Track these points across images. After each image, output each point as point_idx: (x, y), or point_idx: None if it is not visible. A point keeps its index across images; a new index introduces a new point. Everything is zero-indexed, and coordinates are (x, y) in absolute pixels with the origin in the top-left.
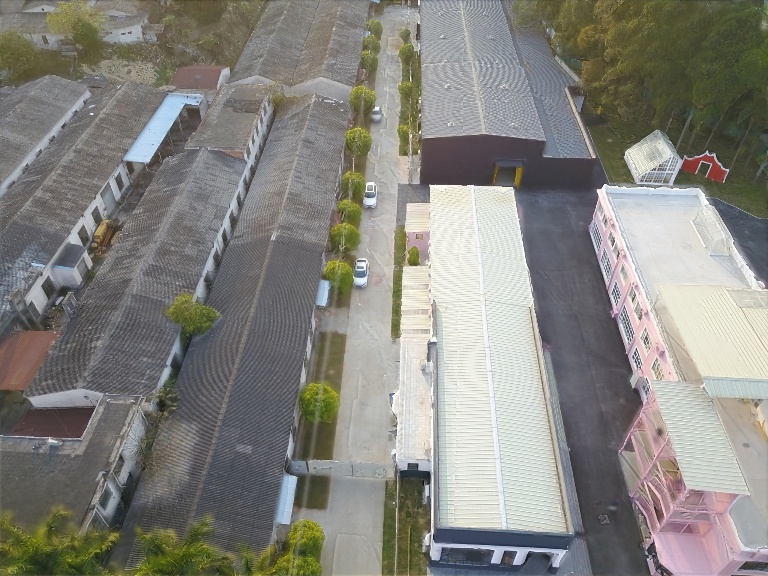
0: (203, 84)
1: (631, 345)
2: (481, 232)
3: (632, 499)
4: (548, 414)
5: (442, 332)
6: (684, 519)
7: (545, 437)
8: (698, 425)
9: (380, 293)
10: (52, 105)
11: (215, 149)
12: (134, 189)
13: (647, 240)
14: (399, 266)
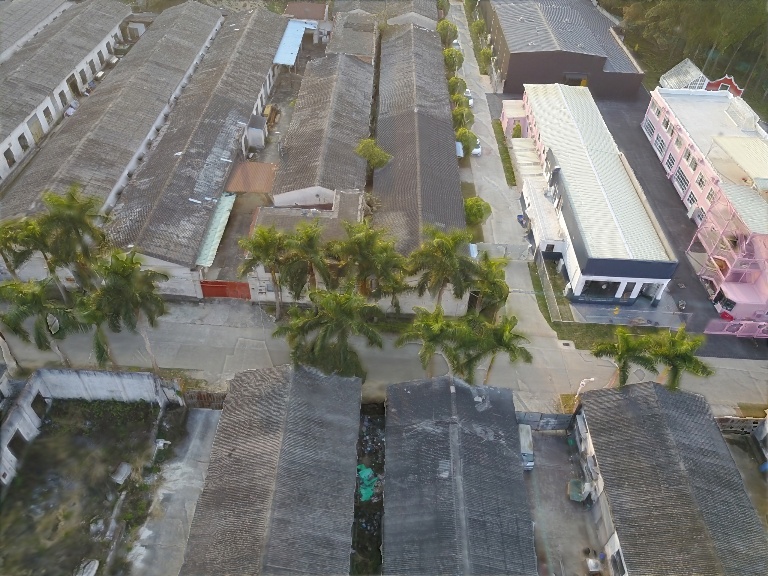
0: (313, 15)
1: (686, 191)
2: (573, 111)
3: (699, 276)
4: (646, 209)
5: (560, 166)
6: (743, 269)
7: (647, 220)
8: (753, 205)
9: (492, 160)
10: (201, 22)
11: (350, 54)
12: (277, 89)
13: (694, 121)
14: (501, 144)
